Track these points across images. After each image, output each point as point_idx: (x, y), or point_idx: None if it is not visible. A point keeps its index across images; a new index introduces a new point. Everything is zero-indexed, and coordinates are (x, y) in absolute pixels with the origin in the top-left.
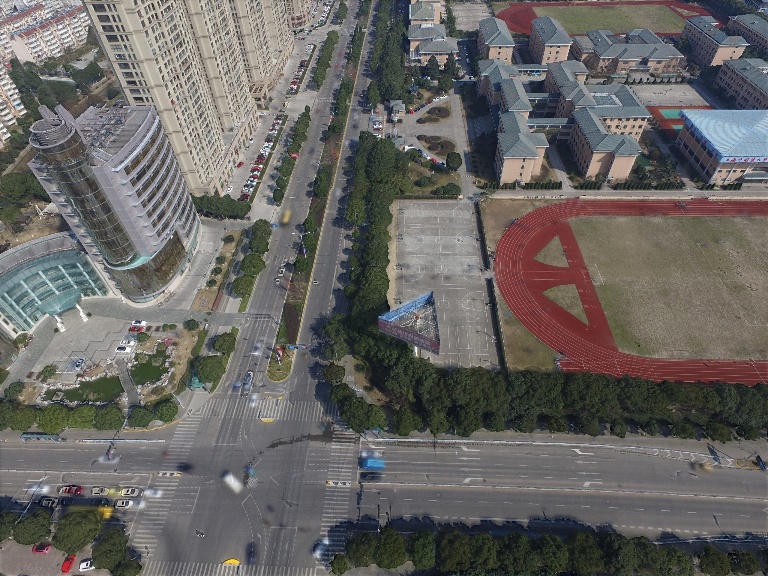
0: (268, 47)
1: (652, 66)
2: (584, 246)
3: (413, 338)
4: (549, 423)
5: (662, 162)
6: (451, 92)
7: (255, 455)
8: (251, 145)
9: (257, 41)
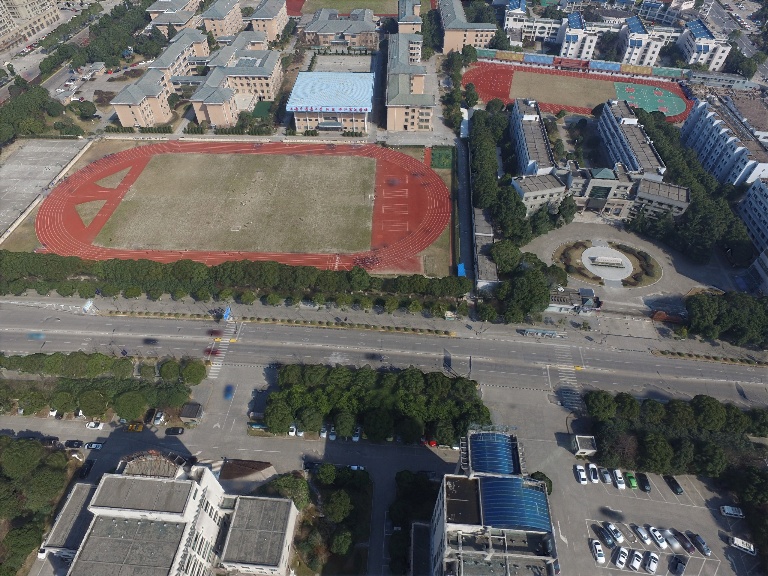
0: None
1: (349, 40)
2: (144, 174)
3: None
4: None
5: None
6: None
7: None
8: None
9: None
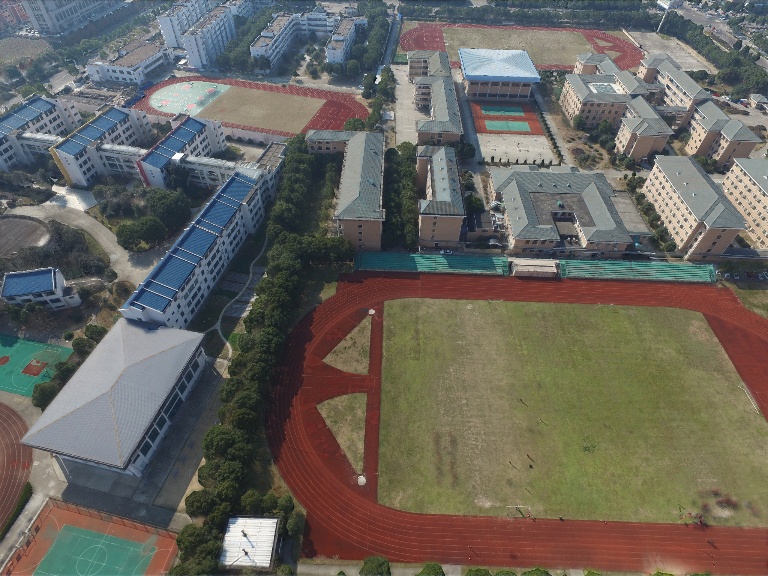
0: None
1: None
2: None
3: None
4: None
5: None
6: None
7: (695, 22)
8: None
9: None
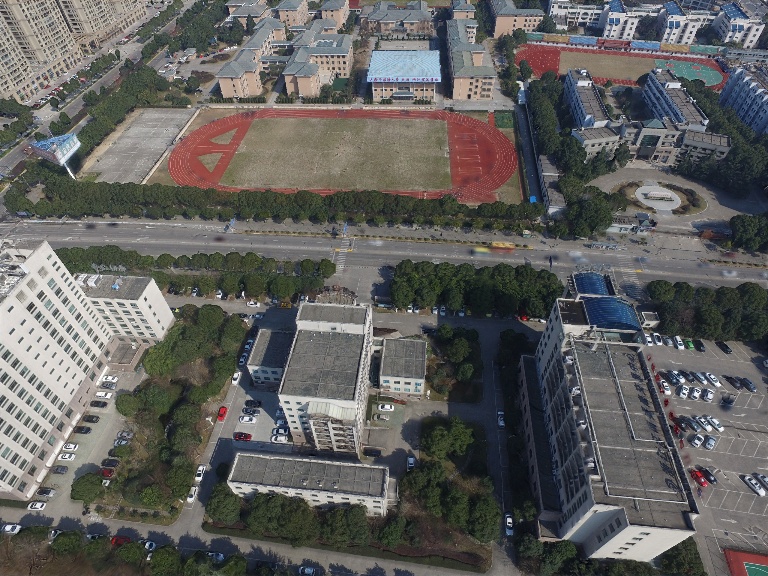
0: (102, 7)
1: (408, 27)
2: (249, 133)
3: (46, 155)
4: None
5: None
6: (243, 44)
7: None
8: (64, 76)
9: (85, 1)
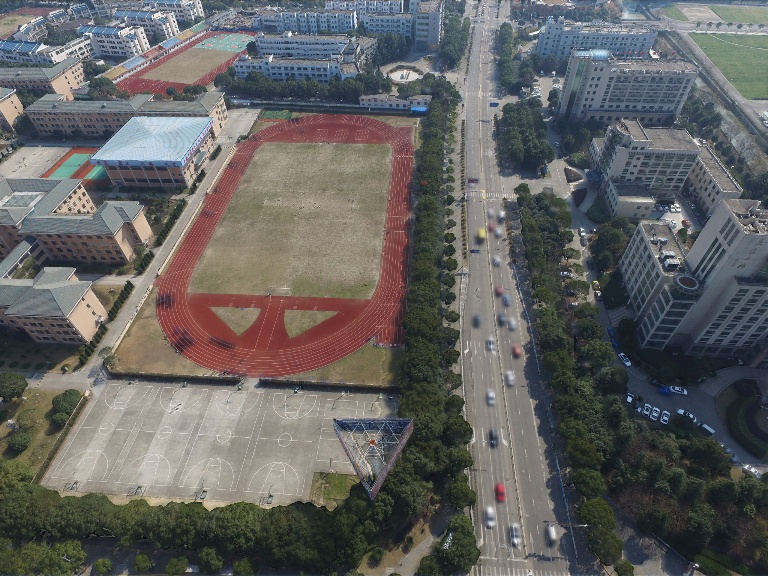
0: None
1: None
2: (235, 290)
3: None
4: (453, 361)
5: (139, 202)
6: None
7: None
8: None
9: None
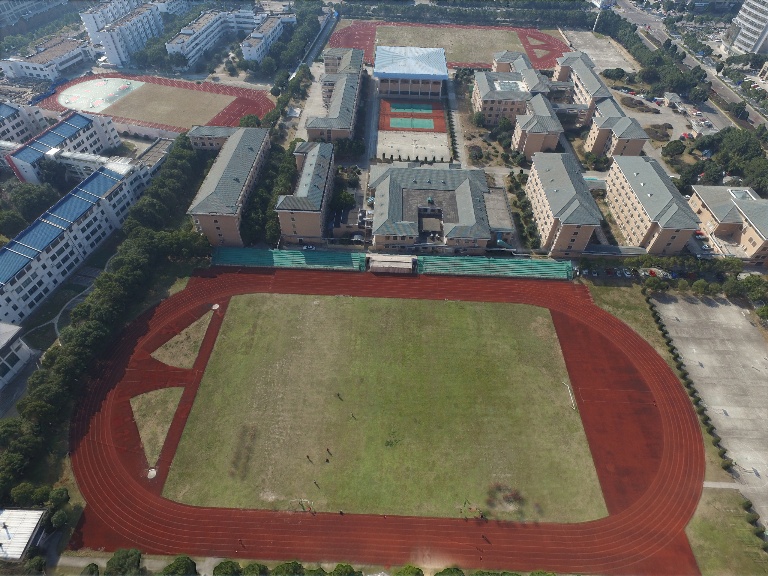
0: None
1: None
2: None
3: None
4: None
5: None
6: (661, 161)
7: (634, 21)
8: None
9: None
